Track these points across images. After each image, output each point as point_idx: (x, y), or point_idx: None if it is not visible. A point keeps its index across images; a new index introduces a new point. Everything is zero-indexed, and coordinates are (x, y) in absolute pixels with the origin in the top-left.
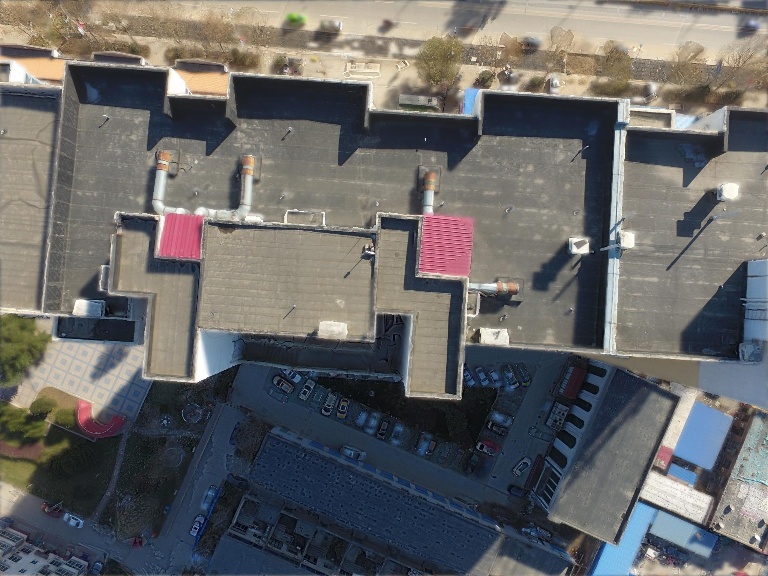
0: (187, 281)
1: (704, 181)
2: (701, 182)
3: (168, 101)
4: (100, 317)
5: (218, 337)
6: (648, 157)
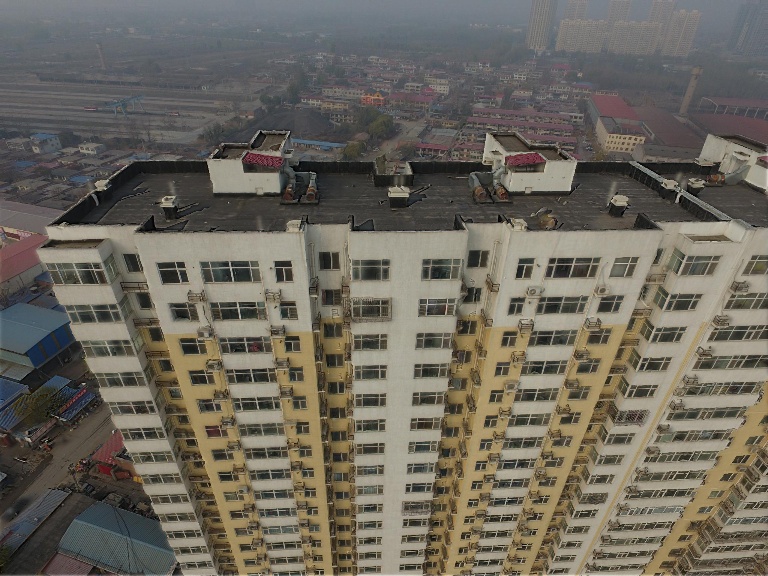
0: None
1: None
2: (630, 220)
3: None
4: None
5: None
6: None
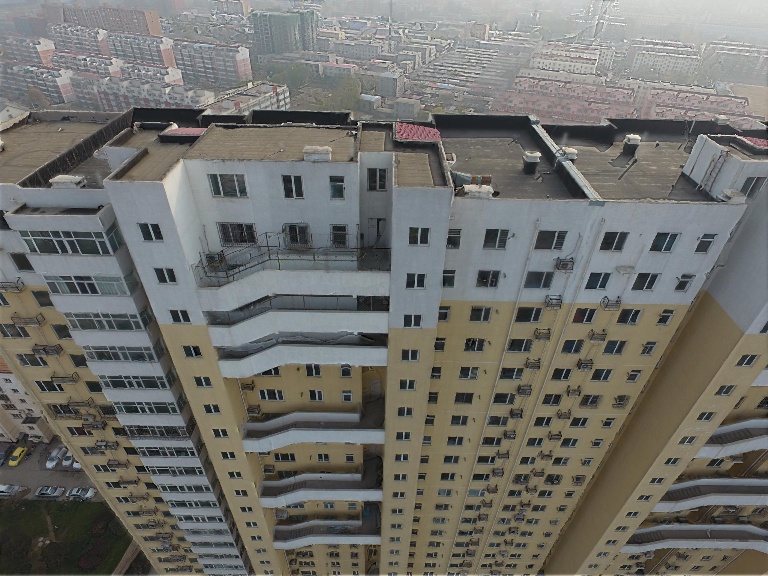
0: (182, 149)
1: (615, 150)
2: (613, 151)
3: (201, 116)
4: (75, 189)
5: (194, 198)
6: (565, 143)
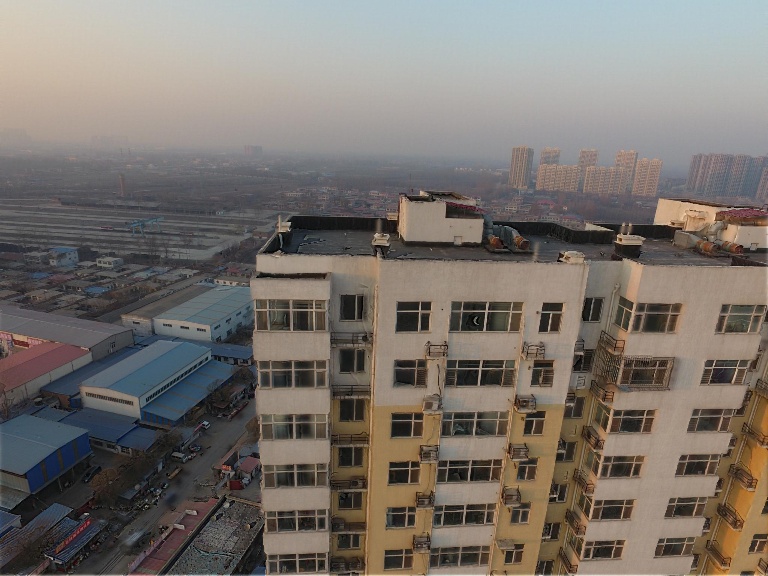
0: None
1: None
2: None
3: None
4: None
5: None
6: None
